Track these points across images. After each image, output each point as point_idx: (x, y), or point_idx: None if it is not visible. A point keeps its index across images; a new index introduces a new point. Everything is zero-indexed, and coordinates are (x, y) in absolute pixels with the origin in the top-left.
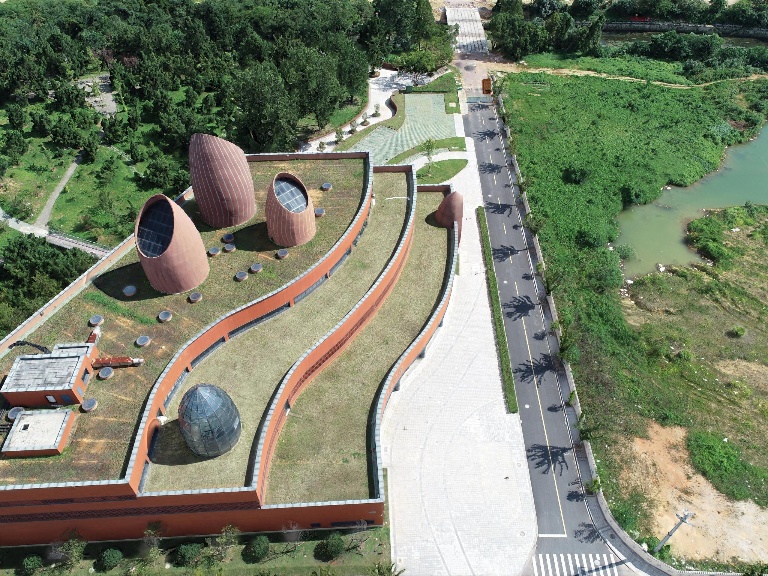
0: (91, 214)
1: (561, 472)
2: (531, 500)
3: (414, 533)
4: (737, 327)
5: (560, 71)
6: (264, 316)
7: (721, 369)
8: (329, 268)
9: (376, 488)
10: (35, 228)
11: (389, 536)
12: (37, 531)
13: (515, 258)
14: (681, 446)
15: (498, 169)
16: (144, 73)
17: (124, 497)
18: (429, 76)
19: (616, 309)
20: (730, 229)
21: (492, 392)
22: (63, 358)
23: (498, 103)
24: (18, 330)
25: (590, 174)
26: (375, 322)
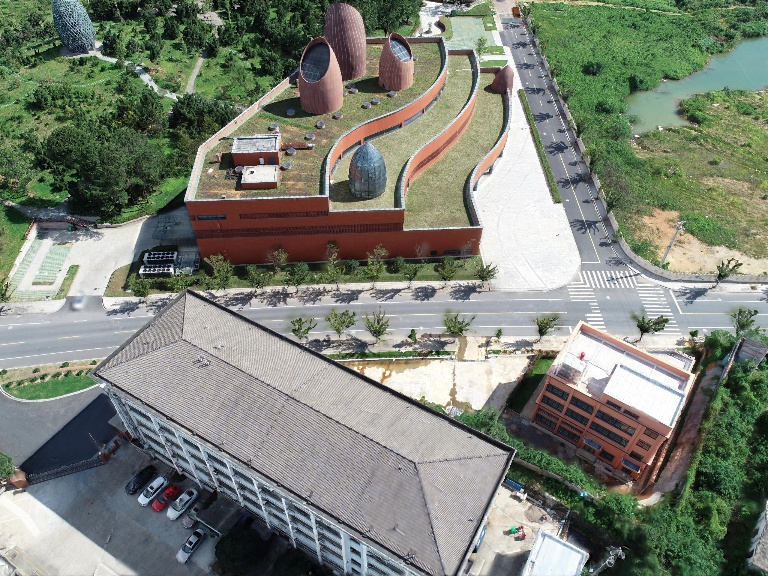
0: None
1: (594, 233)
2: (575, 246)
3: (498, 261)
4: (716, 157)
5: (575, 2)
6: (385, 132)
7: (704, 182)
8: (425, 105)
9: (475, 225)
10: None
11: (482, 262)
12: (253, 248)
13: (551, 120)
14: (676, 220)
15: (531, 67)
16: None
17: (320, 213)
18: (467, 6)
19: (628, 149)
20: (712, 104)
21: (542, 193)
22: (265, 139)
23: (527, 23)
24: (224, 129)
25: (604, 70)
26: (458, 145)
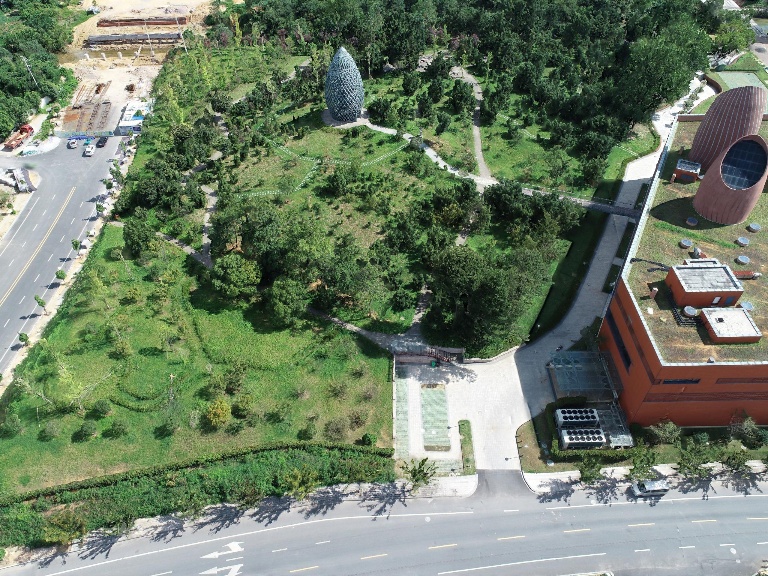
0: (522, 168)
1: None
2: None
3: None
4: None
5: None
6: None
7: None
8: None
9: None
10: (484, 179)
11: None
12: (704, 412)
13: None
14: None
15: None
16: (502, 48)
17: None
18: None
19: None
20: None
21: None
22: (710, 268)
23: None
24: None
25: None
26: None
